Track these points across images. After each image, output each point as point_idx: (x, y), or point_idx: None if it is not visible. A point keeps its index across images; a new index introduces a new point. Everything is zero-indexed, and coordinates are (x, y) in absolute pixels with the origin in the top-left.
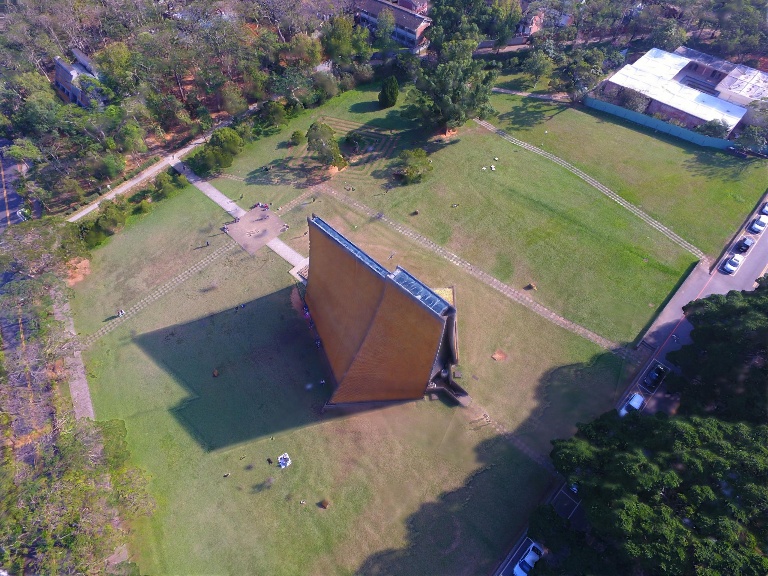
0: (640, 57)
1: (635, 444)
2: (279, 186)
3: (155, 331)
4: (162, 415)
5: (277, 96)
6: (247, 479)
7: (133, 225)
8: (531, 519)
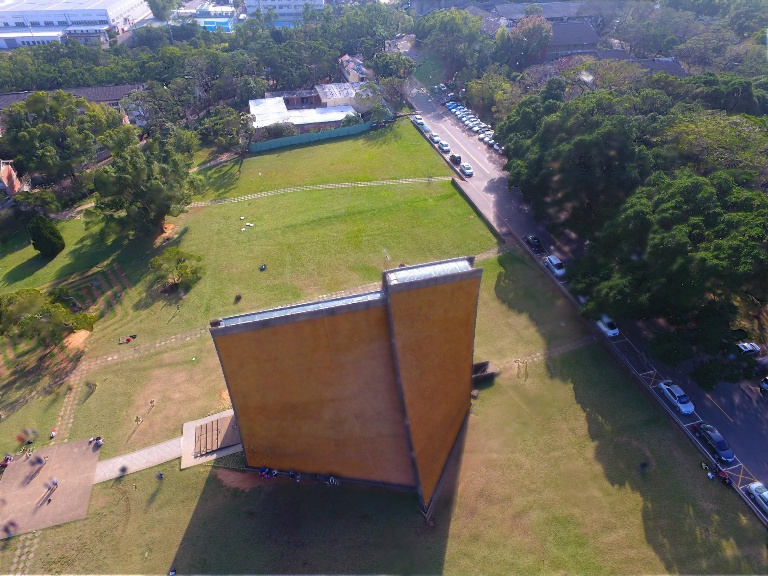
0: (249, 108)
1: None
2: (10, 417)
3: None
4: None
5: None
6: None
7: None
8: (662, 354)
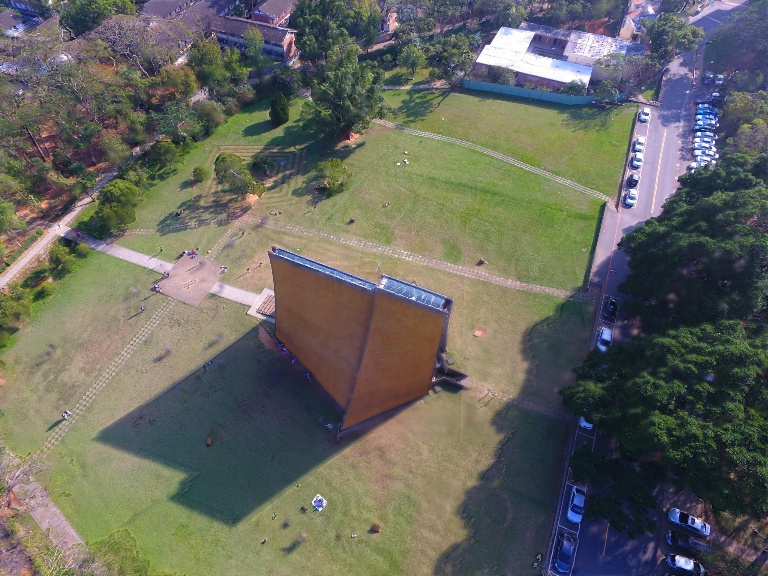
0: (494, 37)
1: (630, 370)
2: (199, 228)
3: (118, 421)
4: (165, 507)
5: (158, 135)
6: (288, 536)
7: (40, 313)
8: (573, 465)
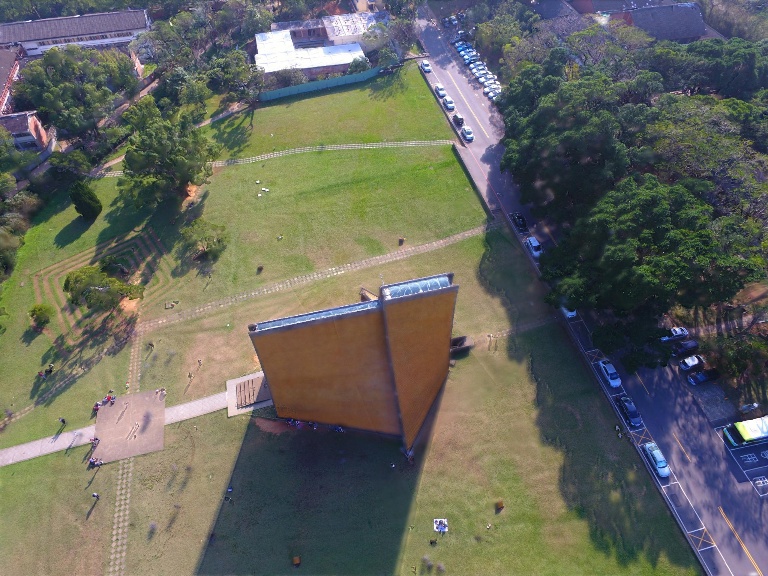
0: (256, 45)
1: None
2: (92, 370)
3: None
4: None
5: None
6: (440, 575)
7: None
8: (600, 344)
